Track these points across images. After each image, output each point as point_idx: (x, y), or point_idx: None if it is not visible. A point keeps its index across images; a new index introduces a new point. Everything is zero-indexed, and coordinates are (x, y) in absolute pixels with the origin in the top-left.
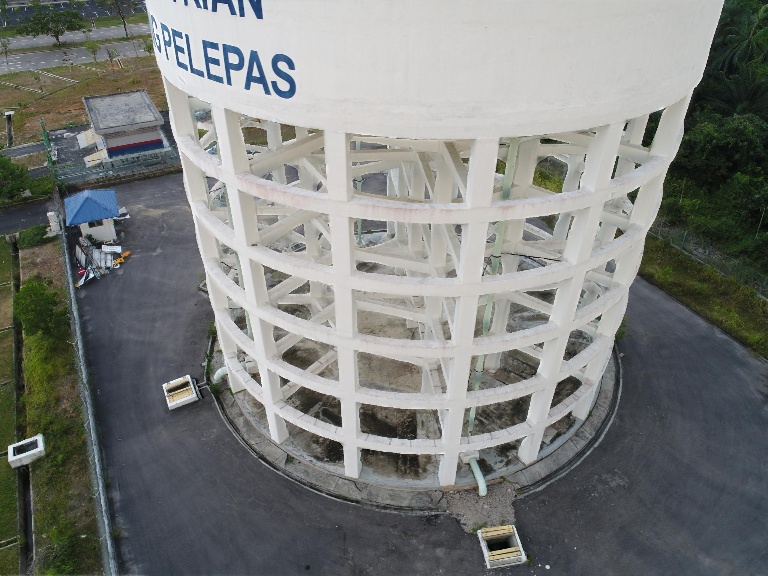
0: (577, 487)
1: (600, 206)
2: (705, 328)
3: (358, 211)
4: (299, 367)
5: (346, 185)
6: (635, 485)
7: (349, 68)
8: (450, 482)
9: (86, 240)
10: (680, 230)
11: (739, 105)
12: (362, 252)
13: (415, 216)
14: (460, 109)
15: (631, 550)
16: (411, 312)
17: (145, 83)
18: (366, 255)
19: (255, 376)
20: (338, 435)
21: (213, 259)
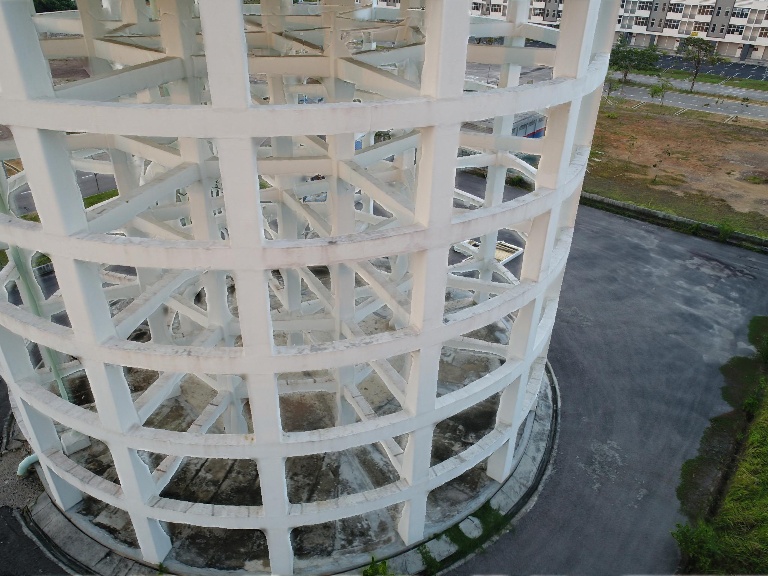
0: (24, 575)
1: None
2: None
3: None
4: (203, 304)
5: None
6: None
7: None
8: None
9: None
10: None
11: None
12: None
13: None
14: None
15: None
16: None
17: (617, 120)
18: None
19: None
20: None
21: None
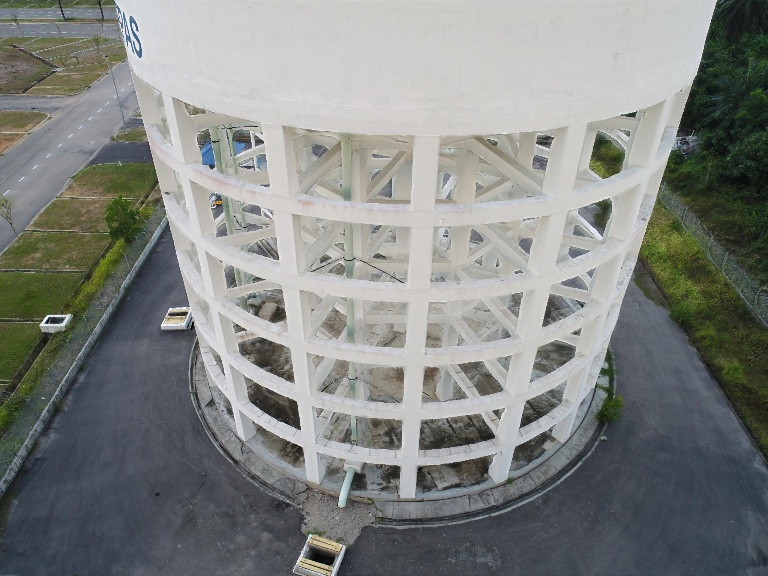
0: (439, 544)
1: (427, 230)
2: (744, 450)
3: (193, 175)
4: None
5: (182, 148)
6: (504, 572)
7: (162, 34)
8: (315, 480)
9: None
10: None
11: None
12: (305, 233)
13: (229, 190)
14: (242, 89)
15: None
16: (341, 305)
17: None
18: (307, 236)
19: (237, 326)
20: (226, 392)
21: None
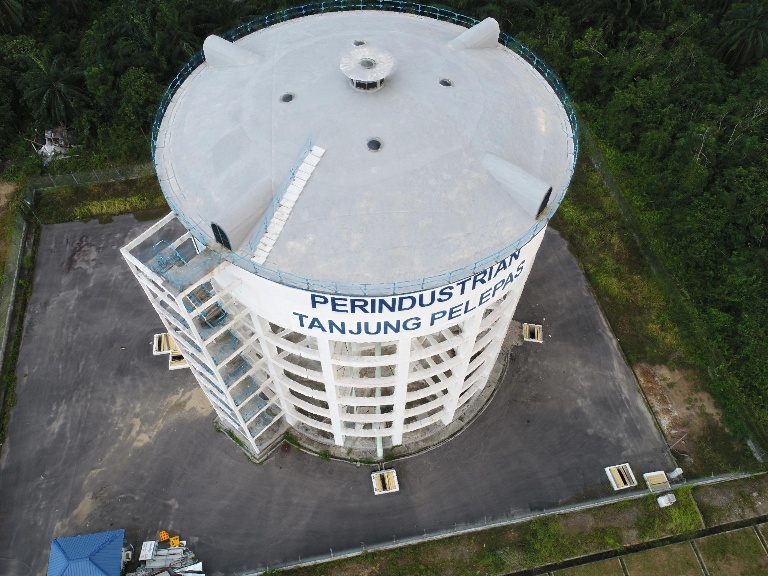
0: None
1: None
2: None
3: None
4: None
5: None
6: None
7: None
8: None
9: (128, 575)
10: None
11: (237, 25)
12: None
13: None
14: None
15: (542, 284)
16: None
17: None
18: None
19: None
20: None
21: (407, 394)
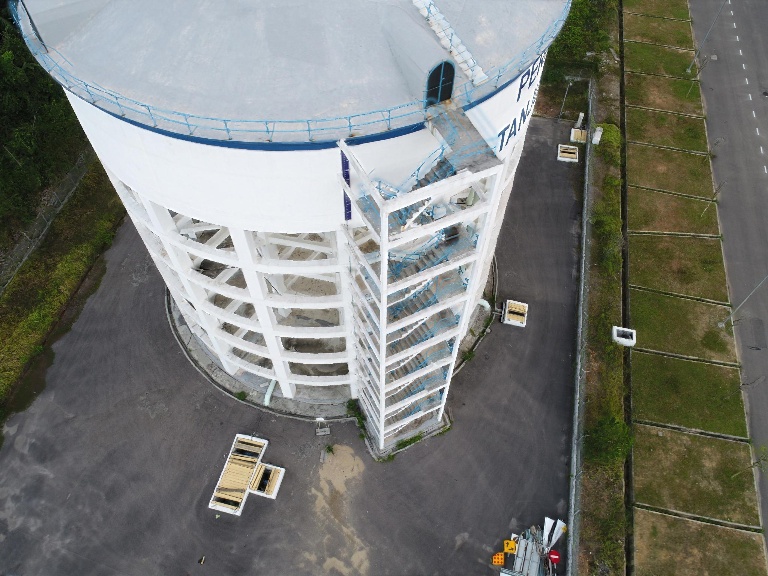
0: None
1: None
2: None
3: None
4: None
5: None
6: None
7: None
8: None
9: None
10: (22, 219)
11: None
12: None
13: None
14: None
15: None
16: None
17: None
18: None
19: None
20: None
21: None
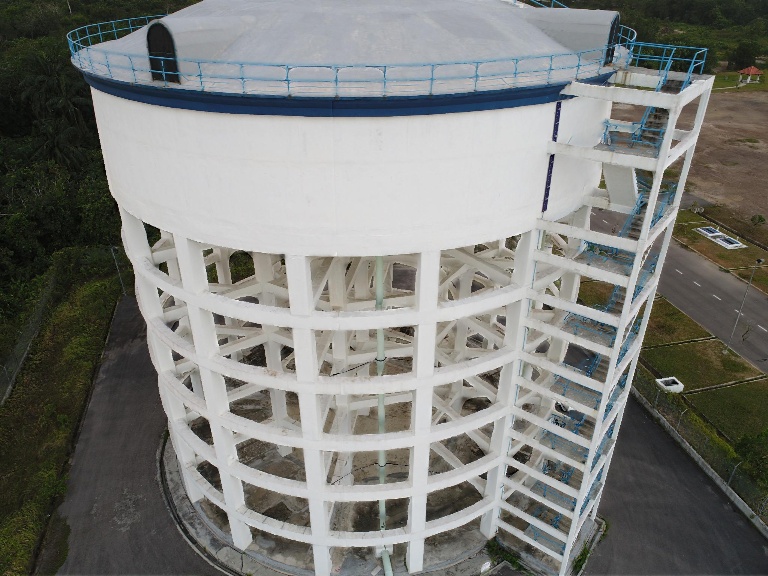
0: None
1: None
2: (105, 383)
3: None
4: None
5: None
6: None
7: None
8: None
9: None
10: None
11: None
12: None
13: None
14: None
15: None
16: None
17: None
18: None
19: None
20: None
21: None
